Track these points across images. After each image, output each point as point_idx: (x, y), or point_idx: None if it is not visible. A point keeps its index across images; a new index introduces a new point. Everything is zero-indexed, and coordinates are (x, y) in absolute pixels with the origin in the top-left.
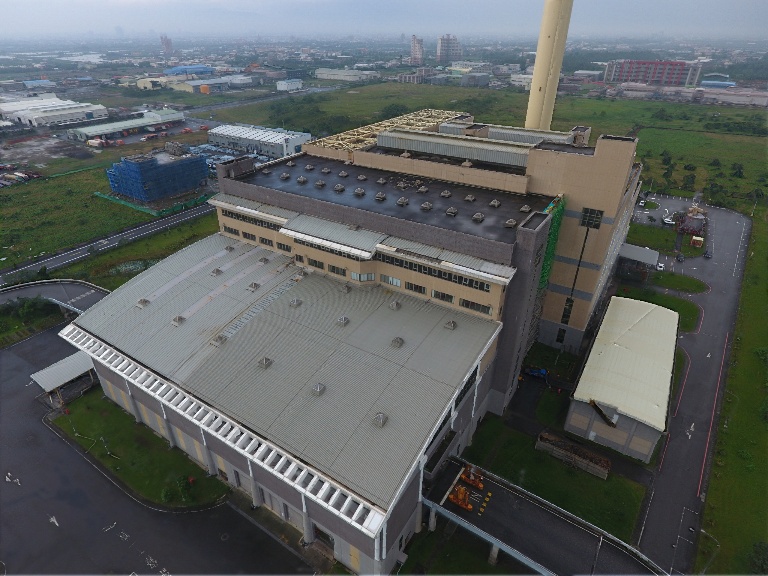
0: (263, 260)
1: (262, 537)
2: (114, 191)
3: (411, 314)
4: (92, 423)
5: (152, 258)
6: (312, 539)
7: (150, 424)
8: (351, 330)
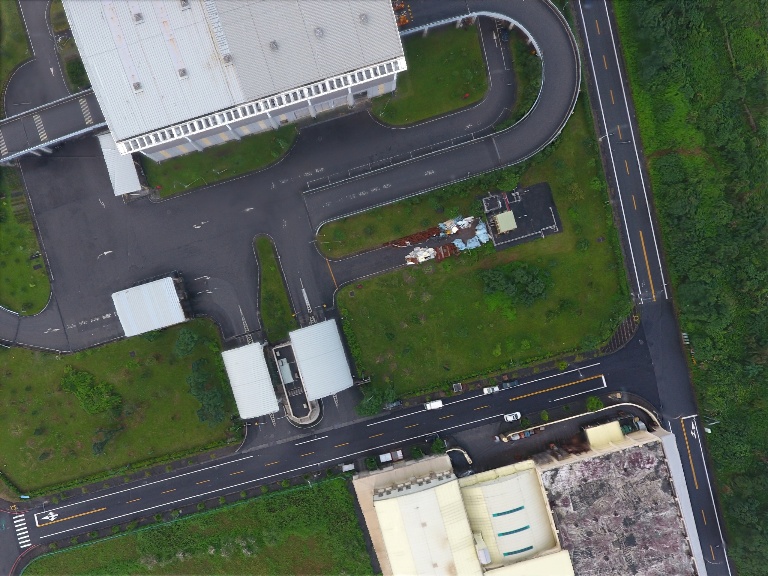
0: None
1: (333, 123)
2: None
3: None
4: (182, 176)
5: None
6: (353, 102)
7: (212, 144)
8: None
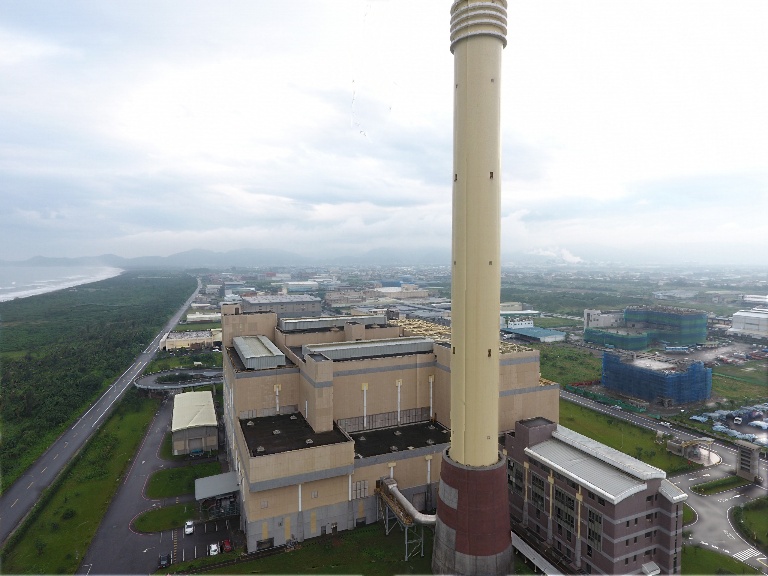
0: None
1: None
2: None
3: None
4: None
5: None
6: None
7: None
8: None
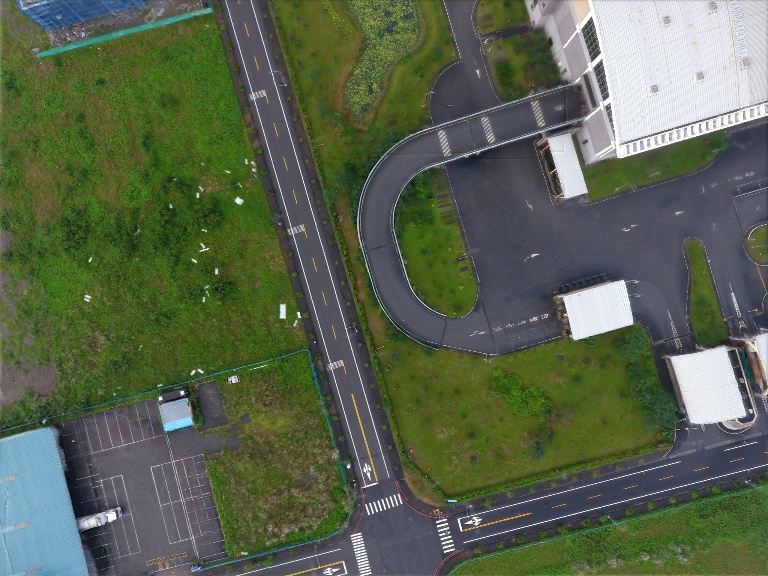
0: None
1: (763, 127)
2: (55, 28)
3: None
4: (613, 179)
5: (357, 62)
6: None
7: None
8: None
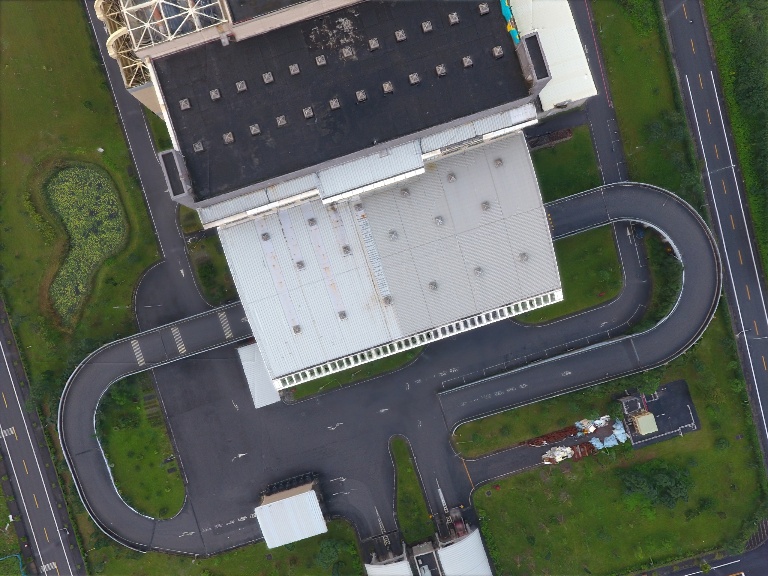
0: (314, 224)
1: None
2: None
3: (467, 175)
4: None
5: (61, 263)
6: None
7: None
8: (450, 222)
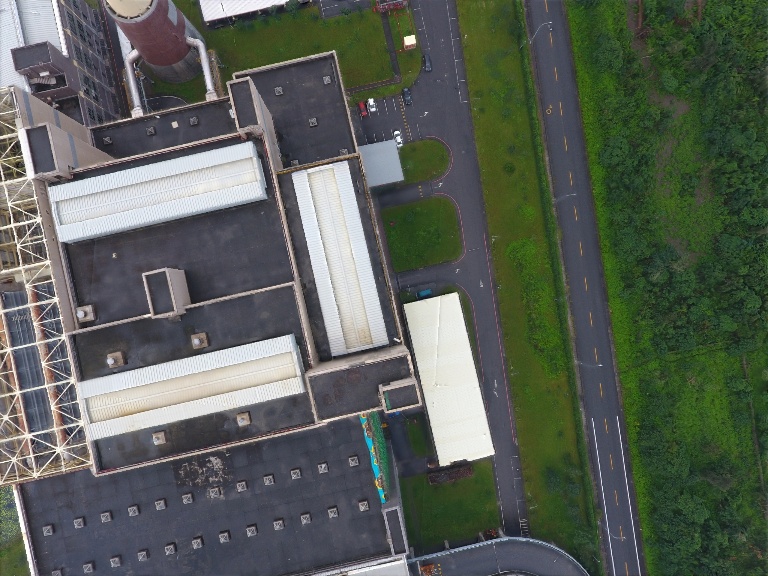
0: None
1: None
2: None
3: None
4: None
5: None
6: None
7: None
8: None
